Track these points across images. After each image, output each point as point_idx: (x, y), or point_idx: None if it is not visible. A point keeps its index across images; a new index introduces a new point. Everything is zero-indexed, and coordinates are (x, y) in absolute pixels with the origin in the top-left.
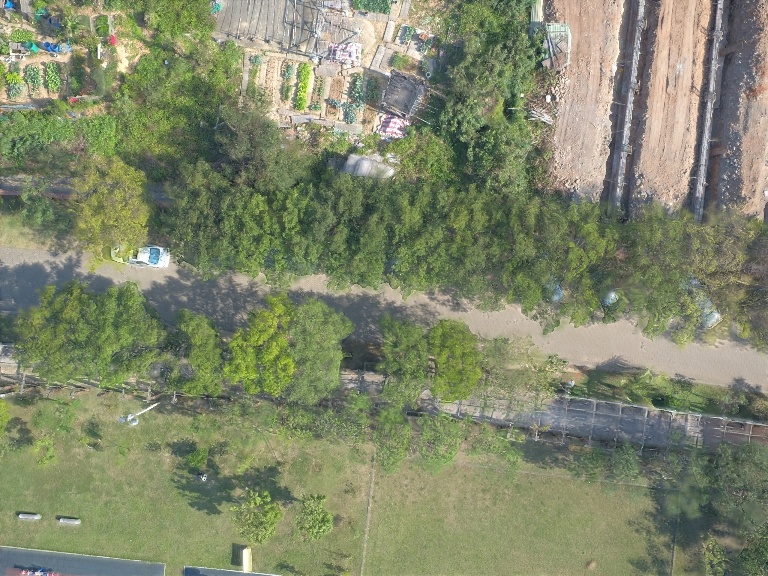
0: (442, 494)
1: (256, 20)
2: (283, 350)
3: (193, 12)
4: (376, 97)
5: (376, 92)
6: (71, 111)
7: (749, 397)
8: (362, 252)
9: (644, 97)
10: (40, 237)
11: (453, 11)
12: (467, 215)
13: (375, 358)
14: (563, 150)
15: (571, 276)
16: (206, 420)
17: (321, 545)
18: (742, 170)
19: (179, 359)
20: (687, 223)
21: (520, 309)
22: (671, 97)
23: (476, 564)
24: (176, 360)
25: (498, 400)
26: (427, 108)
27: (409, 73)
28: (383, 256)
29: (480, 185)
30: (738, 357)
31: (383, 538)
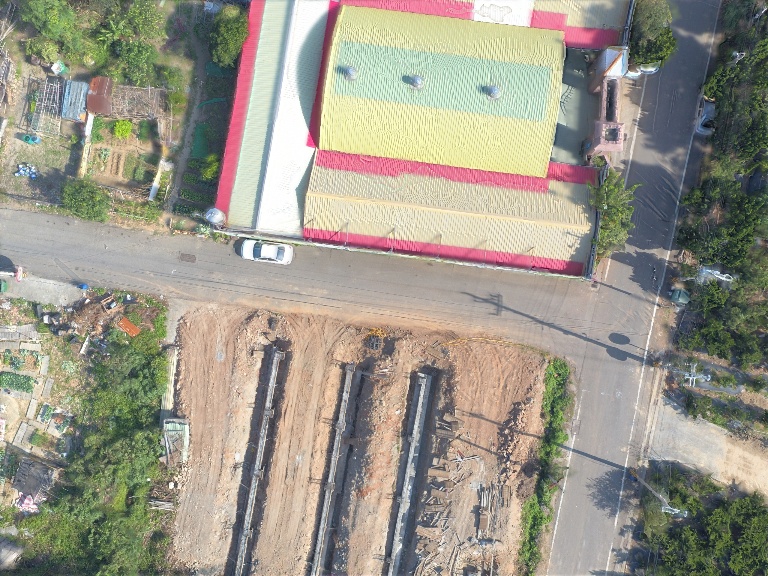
0: None
1: None
2: None
3: None
4: (15, 472)
5: (16, 467)
6: None
7: None
8: None
9: (266, 484)
10: None
11: (90, 394)
12: None
13: None
14: (182, 535)
15: None
16: None
17: None
18: (347, 565)
19: None
20: None
21: None
22: (289, 487)
23: None
24: None
25: None
26: None
27: (48, 450)
28: None
29: None
30: None
31: None
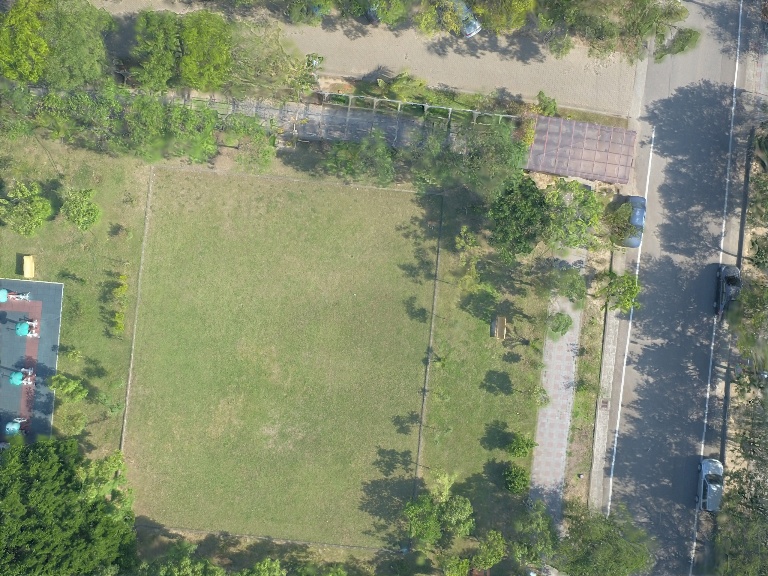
0: (217, 203)
1: None
2: (35, 30)
3: None
4: None
5: None
6: None
7: None
8: None
9: None
10: None
11: None
12: None
13: None
14: None
15: None
16: None
17: (101, 253)
18: None
19: None
20: None
21: (289, 24)
22: None
23: (249, 268)
24: None
25: (268, 110)
26: None
27: None
28: None
29: None
30: (499, 67)
31: (160, 245)
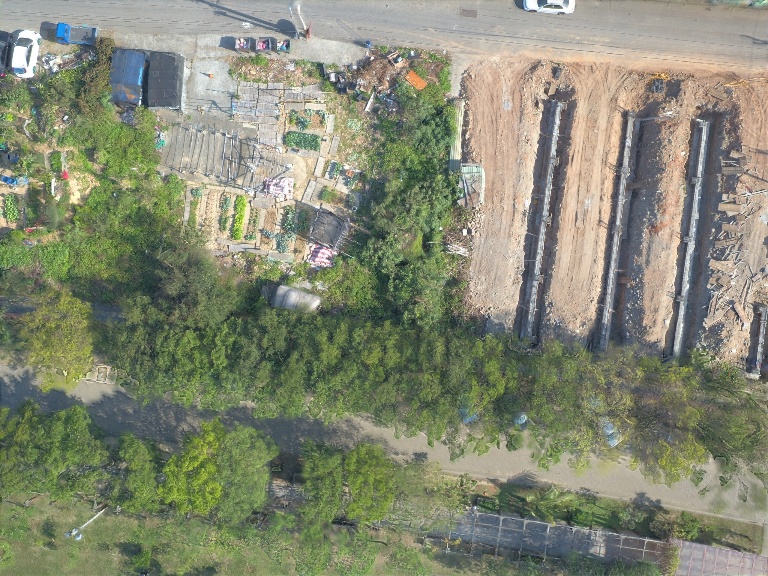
0: None
1: (197, 155)
2: (211, 475)
3: (139, 149)
4: (306, 229)
5: (307, 224)
6: (28, 240)
7: (649, 510)
8: (283, 387)
9: (555, 230)
10: (0, 353)
11: (378, 149)
12: (380, 352)
13: (304, 469)
14: (478, 280)
15: (472, 412)
16: (150, 523)
17: None
18: (644, 301)
19: (119, 478)
20: (582, 362)
21: None
22: (580, 230)
23: None
24: (117, 479)
25: None
26: (353, 239)
27: (337, 206)
28: (302, 390)
29: (400, 312)
30: (639, 472)
31: None
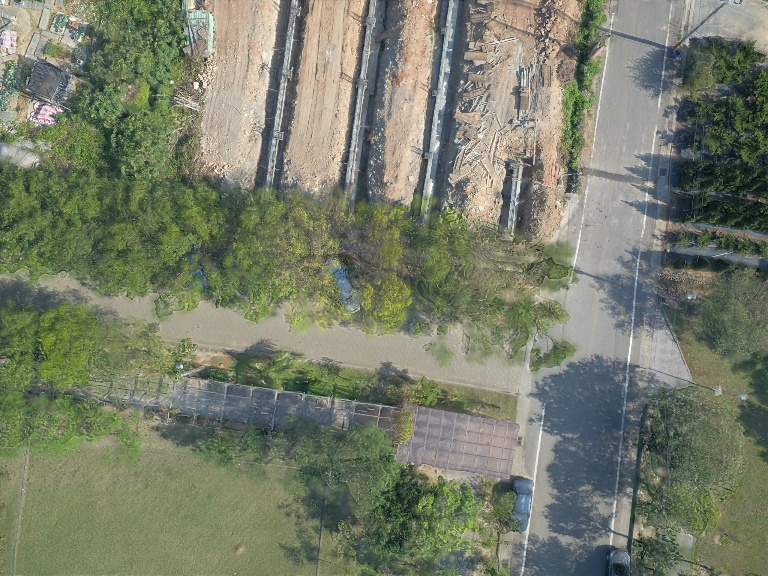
0: (95, 476)
1: None
2: None
3: None
4: None
5: None
6: None
7: (395, 380)
8: None
9: (295, 83)
10: None
11: None
12: (80, 200)
13: None
14: (210, 136)
15: (170, 259)
16: None
17: None
18: (385, 155)
19: None
20: (294, 207)
21: None
22: (320, 83)
23: (128, 545)
24: None
25: None
26: (80, 95)
27: (63, 60)
28: None
29: None
30: (385, 341)
31: (37, 519)
